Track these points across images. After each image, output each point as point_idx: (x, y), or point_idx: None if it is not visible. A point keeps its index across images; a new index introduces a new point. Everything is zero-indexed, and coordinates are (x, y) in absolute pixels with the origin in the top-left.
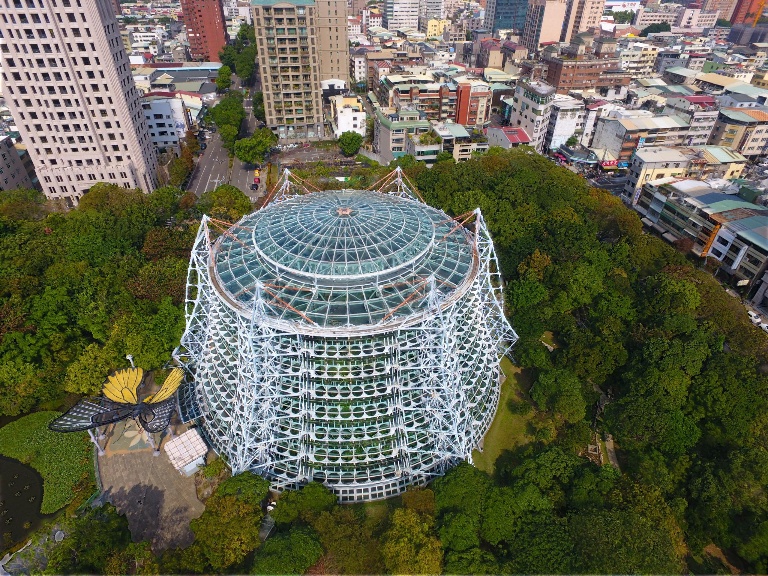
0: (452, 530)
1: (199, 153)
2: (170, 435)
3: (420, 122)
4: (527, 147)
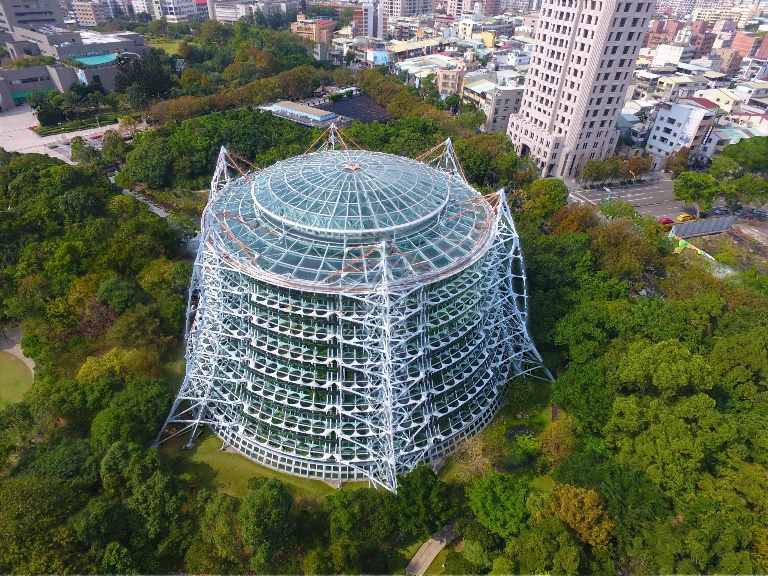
0: None
1: None
2: None
3: None
4: None
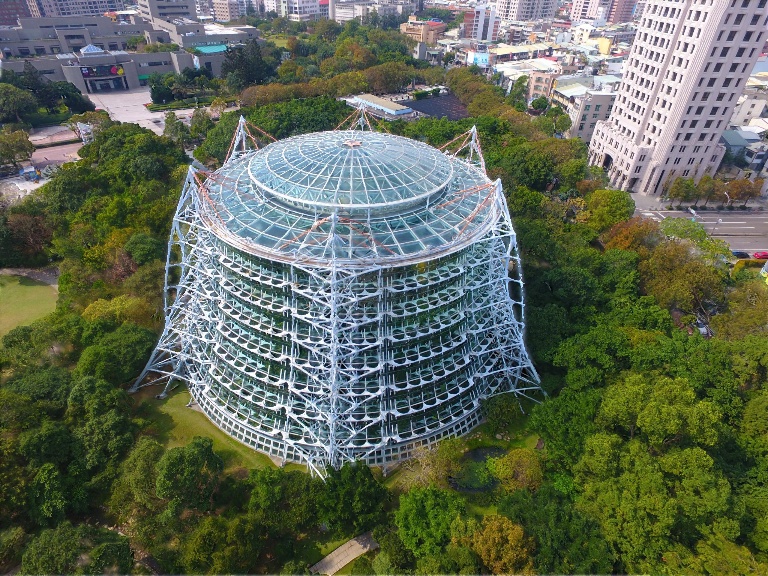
0: None
1: None
2: None
3: None
4: None
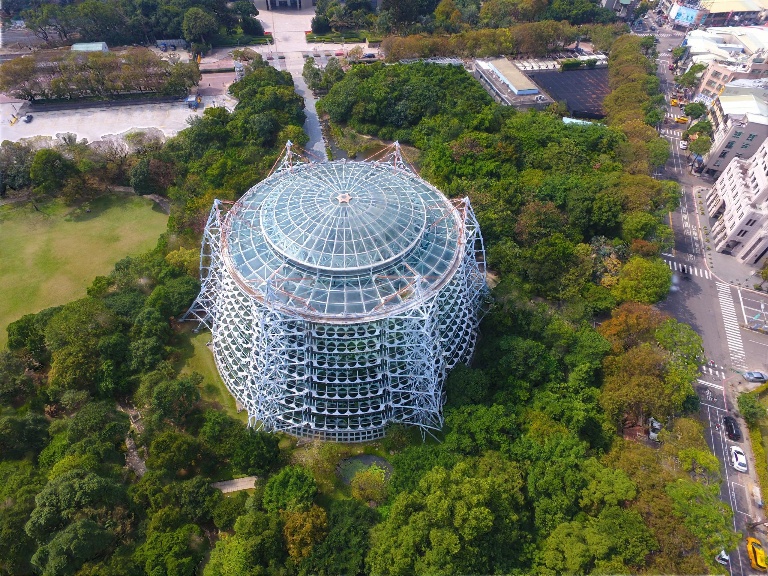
0: None
1: None
2: None
3: None
4: None
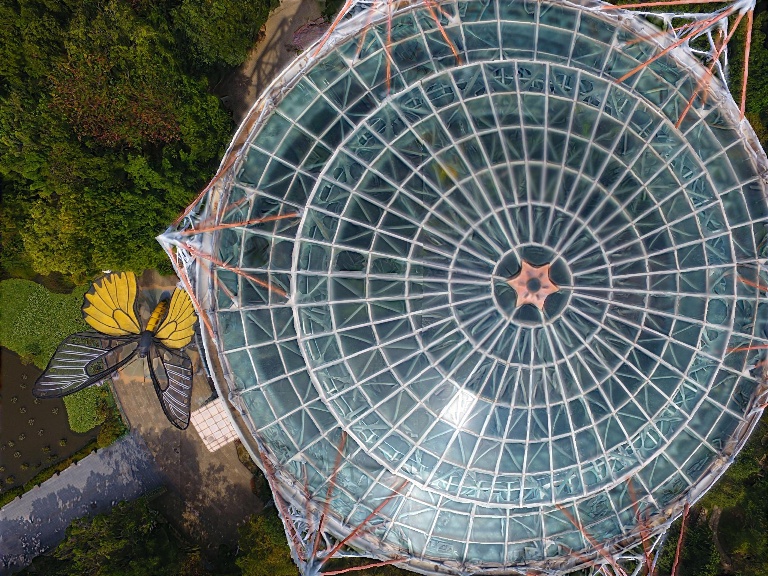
0: None
1: None
2: (194, 366)
3: None
4: None
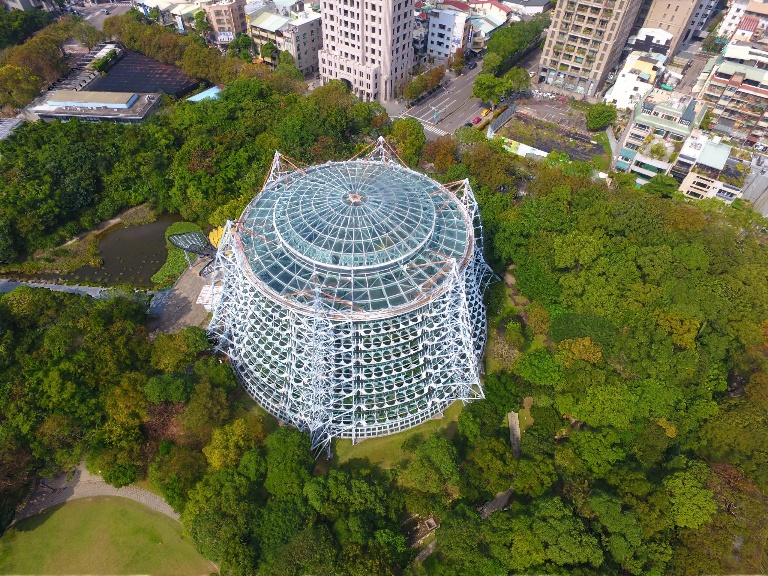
0: (245, 457)
1: (463, 72)
2: None
3: (678, 126)
4: (759, 221)
